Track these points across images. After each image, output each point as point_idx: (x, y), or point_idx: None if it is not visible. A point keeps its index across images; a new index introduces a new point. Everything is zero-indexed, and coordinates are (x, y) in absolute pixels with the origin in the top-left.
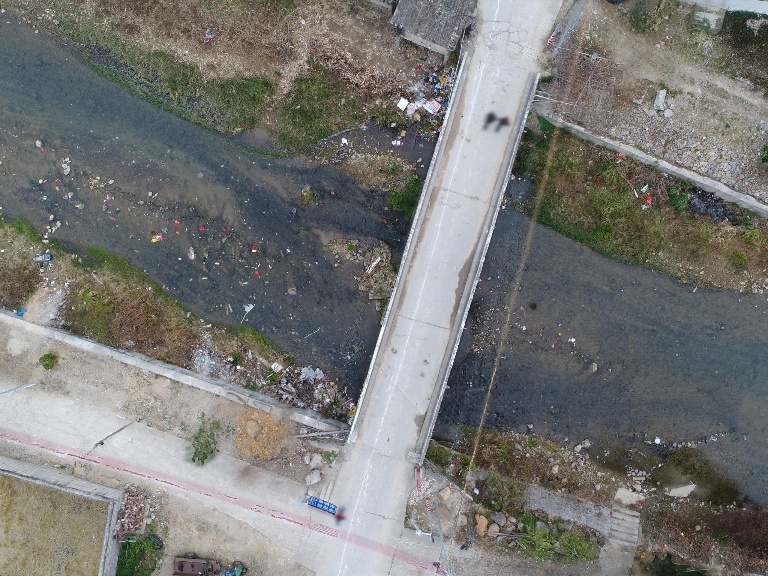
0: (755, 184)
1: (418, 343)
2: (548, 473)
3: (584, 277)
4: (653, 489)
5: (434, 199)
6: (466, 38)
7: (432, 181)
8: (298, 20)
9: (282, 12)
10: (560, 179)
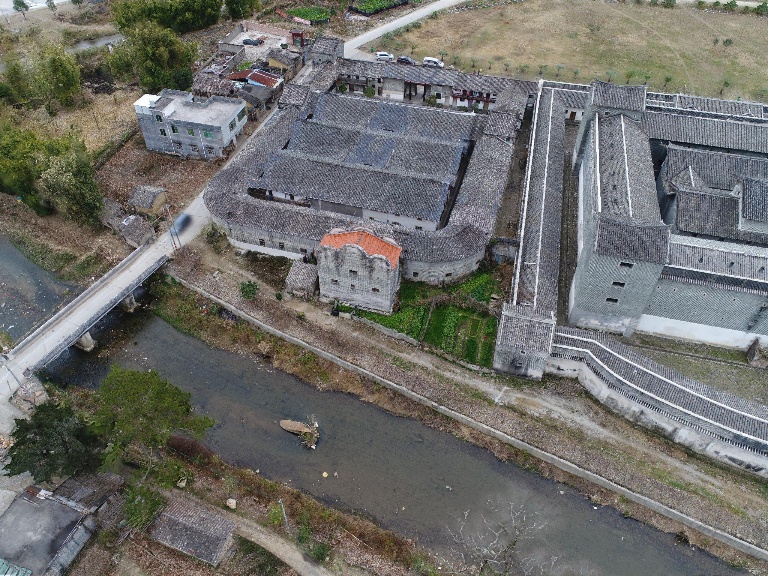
0: (245, 307)
1: (65, 330)
2: None
3: (165, 337)
4: None
5: (105, 286)
6: (148, 244)
7: (108, 280)
8: (99, 239)
9: (94, 237)
10: (172, 300)
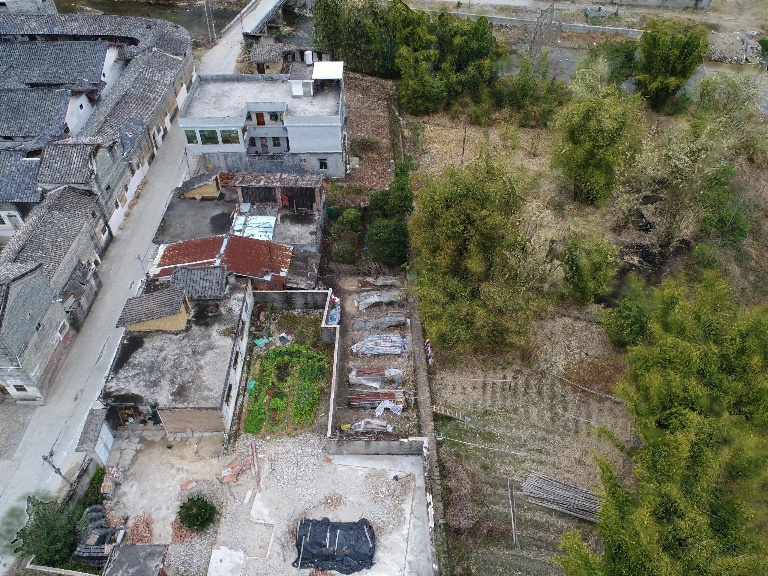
0: None
1: None
2: (228, 4)
3: None
4: (192, 4)
5: None
6: None
7: None
8: None
9: None
10: None
